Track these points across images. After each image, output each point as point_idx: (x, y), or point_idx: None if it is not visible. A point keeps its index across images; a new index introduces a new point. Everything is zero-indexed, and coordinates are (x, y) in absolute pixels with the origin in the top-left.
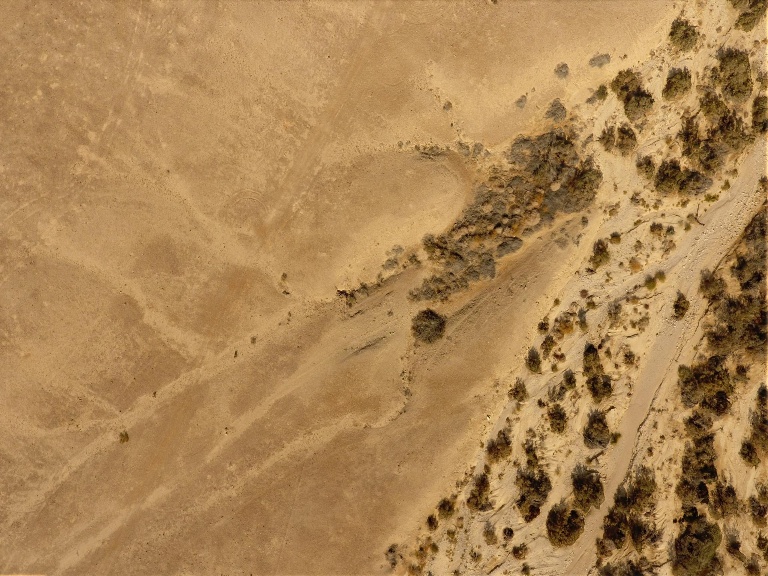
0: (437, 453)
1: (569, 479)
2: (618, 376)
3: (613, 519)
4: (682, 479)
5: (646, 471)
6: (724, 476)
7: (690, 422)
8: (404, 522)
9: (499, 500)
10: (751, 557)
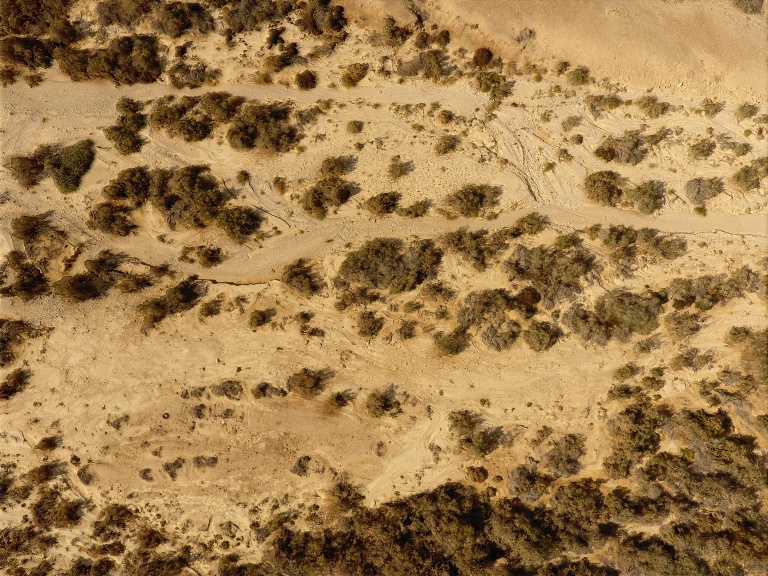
0: (639, 41)
1: (648, 179)
2: (763, 194)
3: (627, 230)
4: (690, 280)
5: (683, 247)
6: (707, 319)
7: (748, 271)
8: (562, 35)
9: (605, 122)
10: (640, 366)
